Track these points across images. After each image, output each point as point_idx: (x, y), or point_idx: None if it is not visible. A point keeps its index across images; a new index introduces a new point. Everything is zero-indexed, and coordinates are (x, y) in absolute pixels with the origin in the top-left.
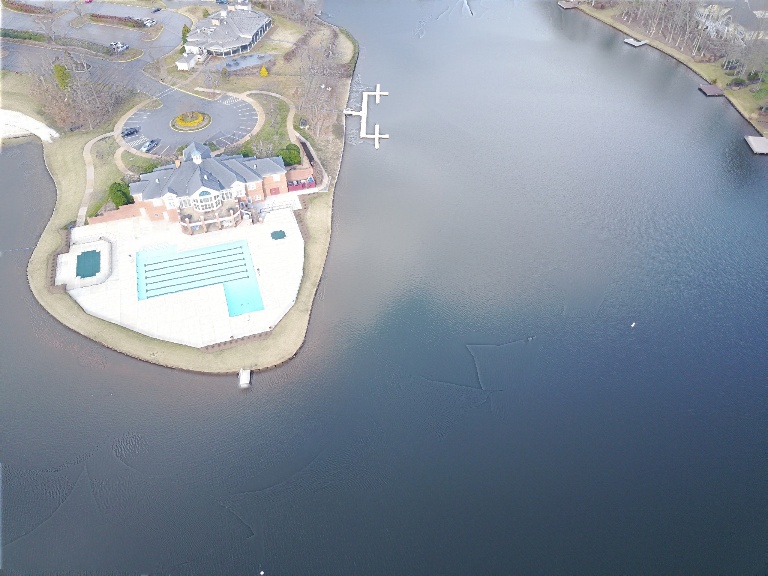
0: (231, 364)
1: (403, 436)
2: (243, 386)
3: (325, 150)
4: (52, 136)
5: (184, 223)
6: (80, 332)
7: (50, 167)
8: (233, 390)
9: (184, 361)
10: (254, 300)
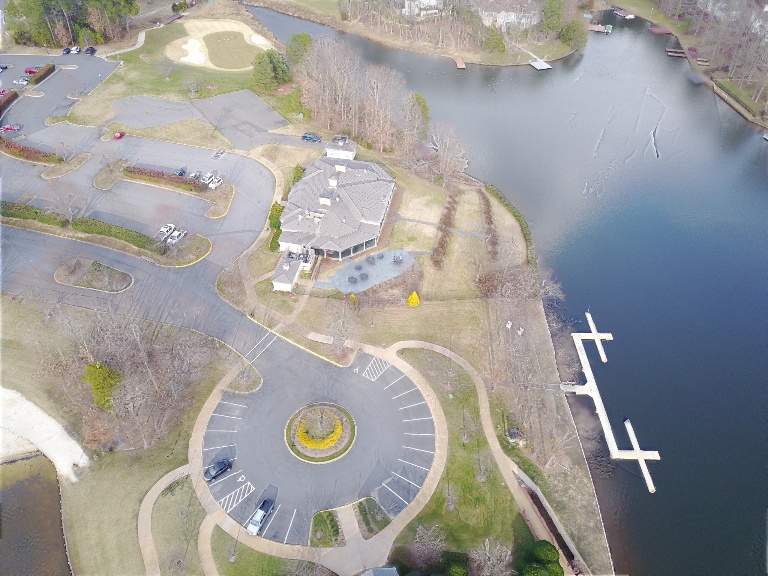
0: None
1: None
2: None
3: (570, 504)
4: (76, 464)
5: None
6: None
7: (75, 564)
8: None
9: None
10: None
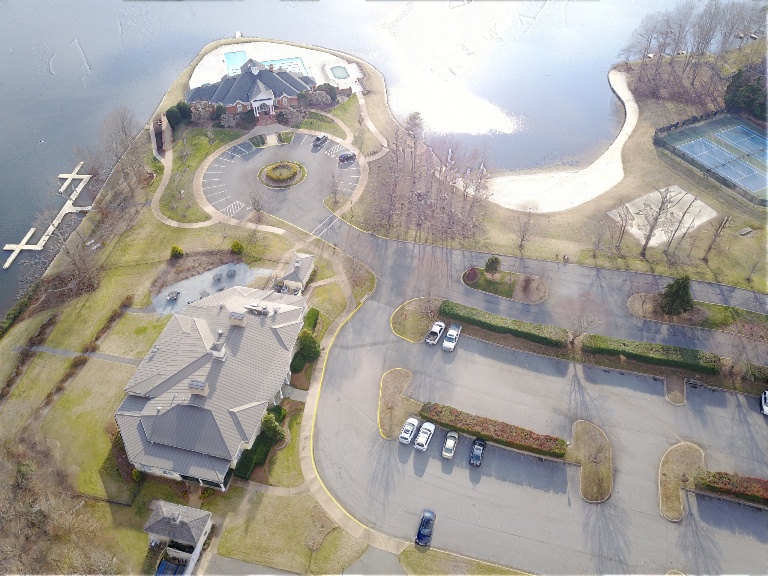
0: None
1: None
2: None
3: (140, 154)
4: None
5: None
6: None
7: None
8: None
9: None
10: None
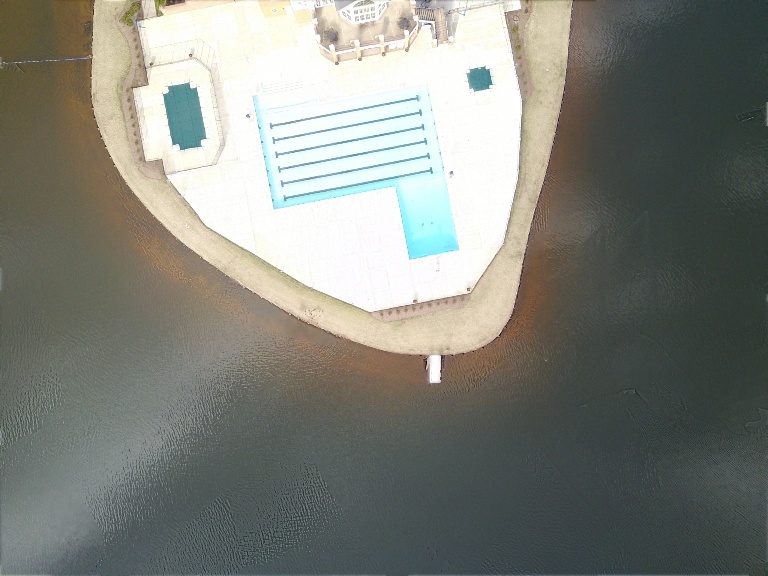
0: (415, 343)
1: (657, 575)
2: (434, 386)
3: None
4: None
5: (326, 49)
6: (203, 257)
7: None
8: (420, 388)
9: (352, 330)
10: (440, 216)
